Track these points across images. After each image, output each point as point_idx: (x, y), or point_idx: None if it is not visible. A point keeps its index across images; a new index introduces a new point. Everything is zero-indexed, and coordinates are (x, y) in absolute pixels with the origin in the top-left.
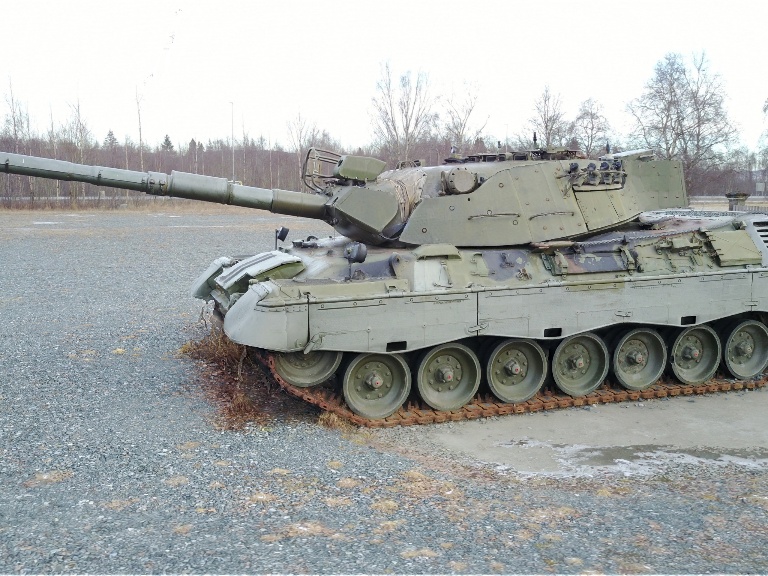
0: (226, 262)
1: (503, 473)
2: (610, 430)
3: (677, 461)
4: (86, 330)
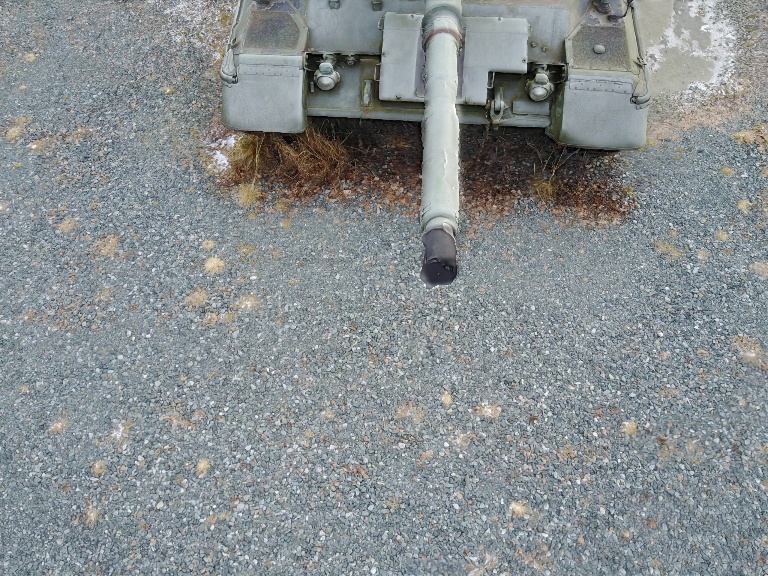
0: (331, 66)
1: (721, 91)
2: (639, 3)
3: (712, 5)
4: (3, 294)
